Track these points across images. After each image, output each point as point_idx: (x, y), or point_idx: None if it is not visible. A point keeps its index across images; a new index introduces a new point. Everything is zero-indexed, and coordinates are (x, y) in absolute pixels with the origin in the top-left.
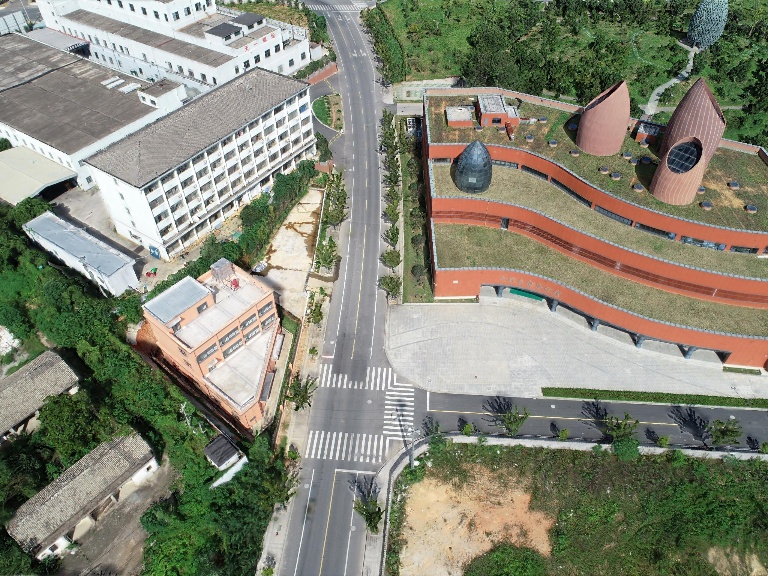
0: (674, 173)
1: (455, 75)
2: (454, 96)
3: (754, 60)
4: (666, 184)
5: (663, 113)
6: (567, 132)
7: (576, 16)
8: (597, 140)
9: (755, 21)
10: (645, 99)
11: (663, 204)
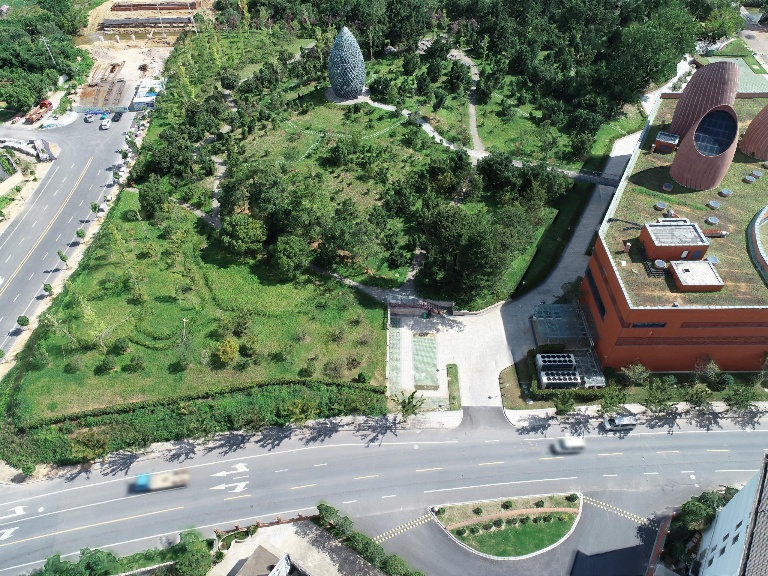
0: None
1: (388, 313)
2: (623, 280)
3: None
4: None
5: None
6: (678, 193)
7: None
8: None
9: None
10: None
11: None
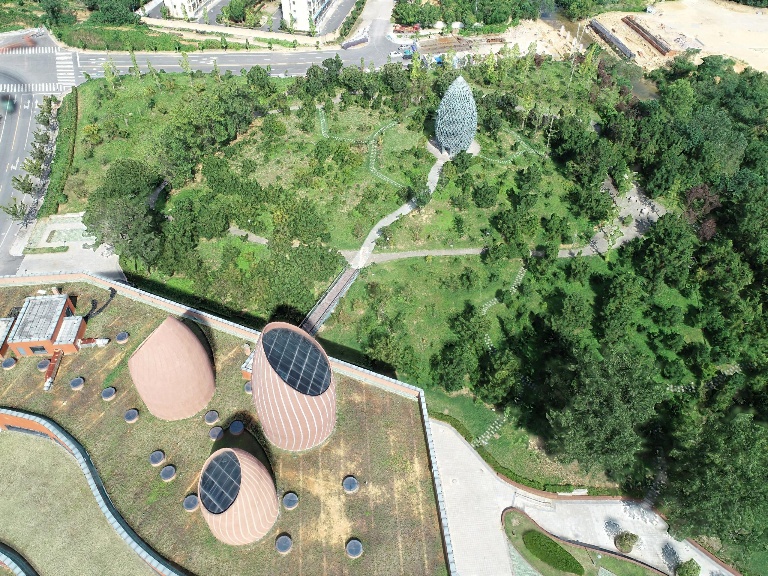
0: (206, 511)
1: None
2: (18, 287)
3: (515, 171)
4: (206, 520)
5: (374, 266)
6: None
7: (314, 103)
8: (151, 403)
9: (525, 111)
10: (359, 241)
11: (215, 543)
